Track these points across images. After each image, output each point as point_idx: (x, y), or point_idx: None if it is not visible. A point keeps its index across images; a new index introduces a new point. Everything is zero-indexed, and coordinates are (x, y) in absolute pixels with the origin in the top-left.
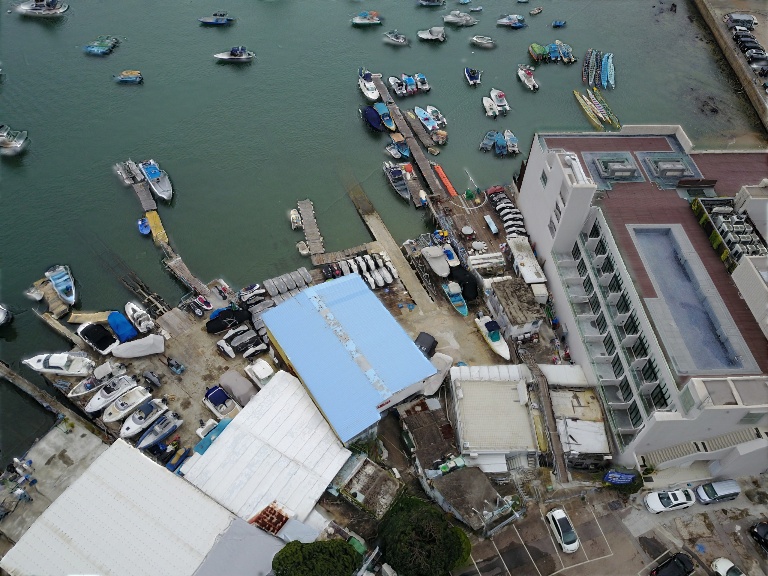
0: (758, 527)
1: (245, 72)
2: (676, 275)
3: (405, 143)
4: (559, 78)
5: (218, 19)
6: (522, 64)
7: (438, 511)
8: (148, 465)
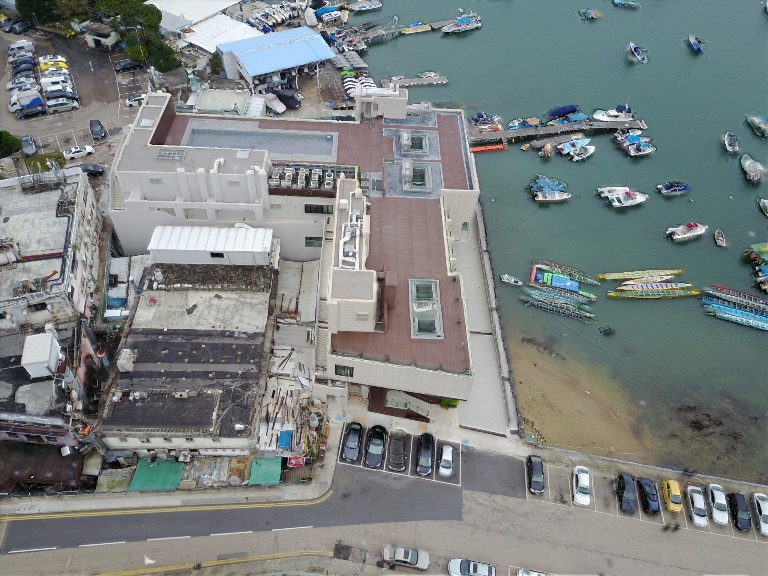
0: (100, 166)
1: (628, 67)
2: (284, 152)
3: (525, 124)
4: (714, 269)
5: (696, 43)
6: (723, 233)
7: (152, 39)
8: (227, 5)
